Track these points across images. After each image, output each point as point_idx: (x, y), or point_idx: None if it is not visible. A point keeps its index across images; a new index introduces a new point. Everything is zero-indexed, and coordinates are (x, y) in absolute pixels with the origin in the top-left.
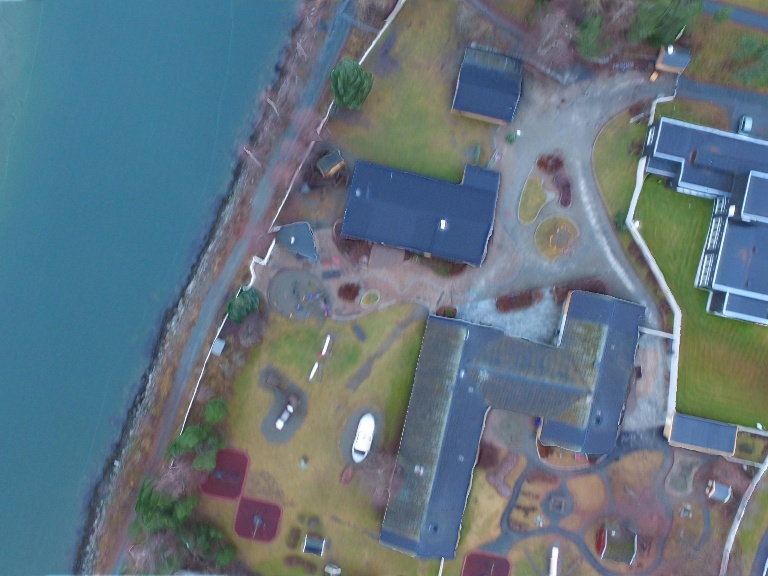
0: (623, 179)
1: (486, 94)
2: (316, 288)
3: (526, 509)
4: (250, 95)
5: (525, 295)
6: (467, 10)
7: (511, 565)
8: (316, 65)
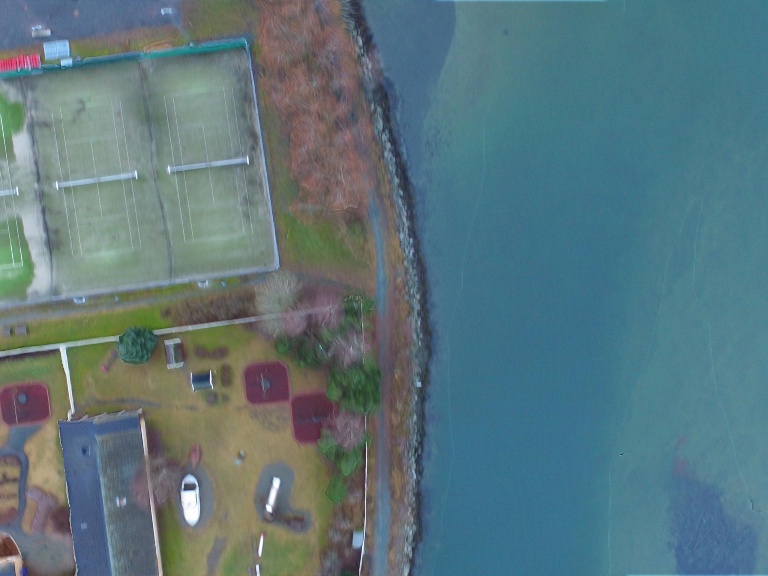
0: None
1: None
2: None
3: (7, 481)
4: None
5: None
6: None
7: (3, 420)
8: None
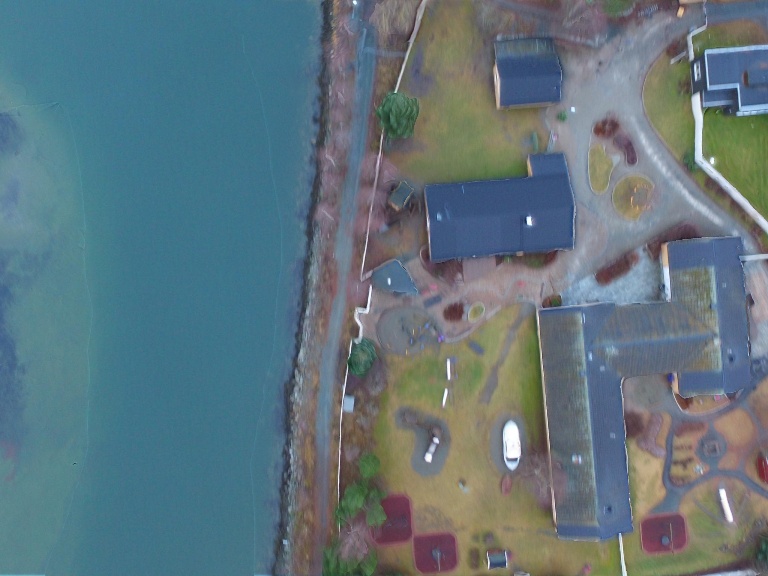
0: (680, 121)
1: (530, 82)
2: (422, 319)
3: (683, 462)
4: (297, 154)
5: (621, 261)
6: (487, 7)
7: (685, 519)
8: (354, 106)
